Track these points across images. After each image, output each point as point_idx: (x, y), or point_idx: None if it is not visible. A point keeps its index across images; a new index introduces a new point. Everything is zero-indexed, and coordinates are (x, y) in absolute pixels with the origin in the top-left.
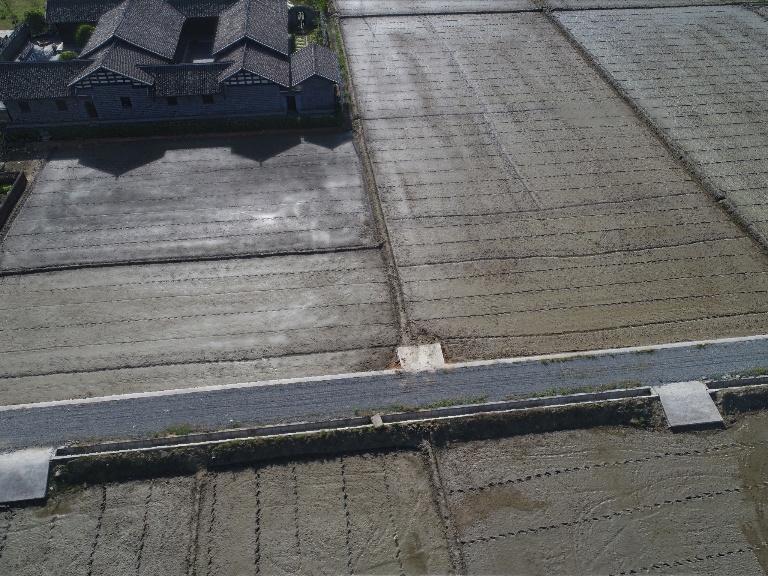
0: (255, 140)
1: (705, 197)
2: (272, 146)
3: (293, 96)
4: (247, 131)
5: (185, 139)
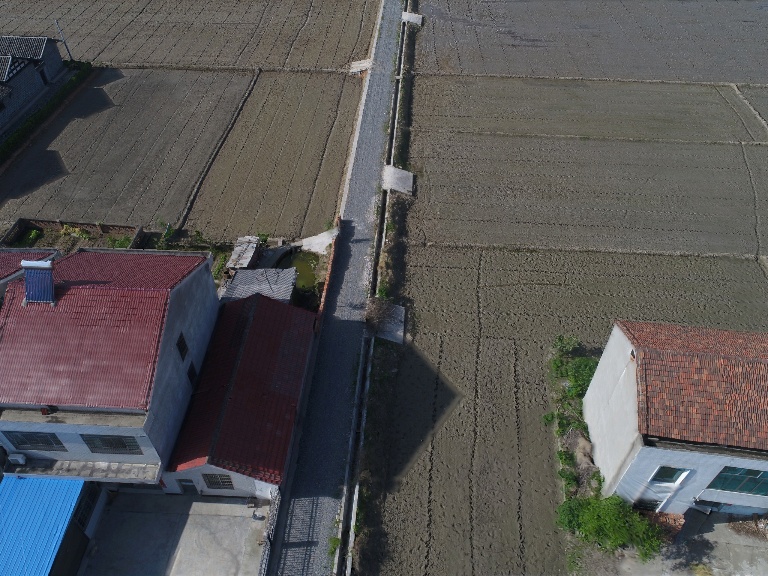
0: (75, 107)
1: None
2: (94, 100)
3: (42, 69)
4: (58, 108)
5: (35, 140)
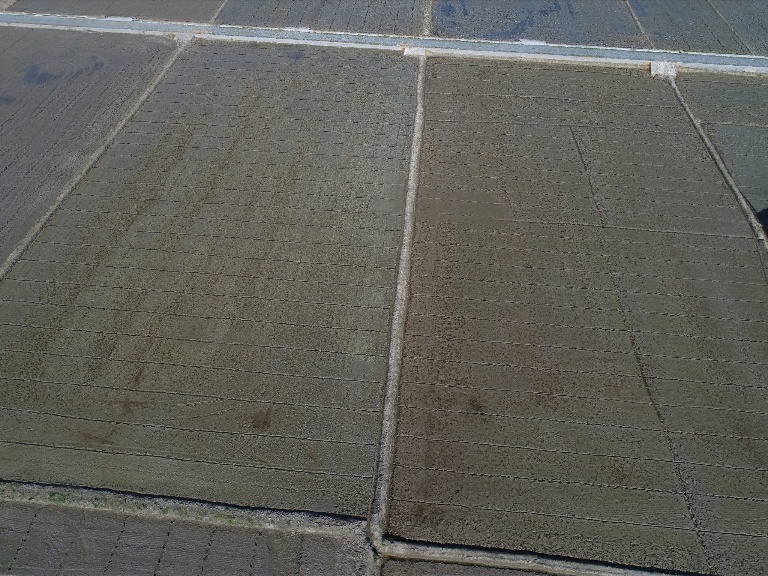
0: None
1: (428, 117)
2: None
3: None
4: None
5: None
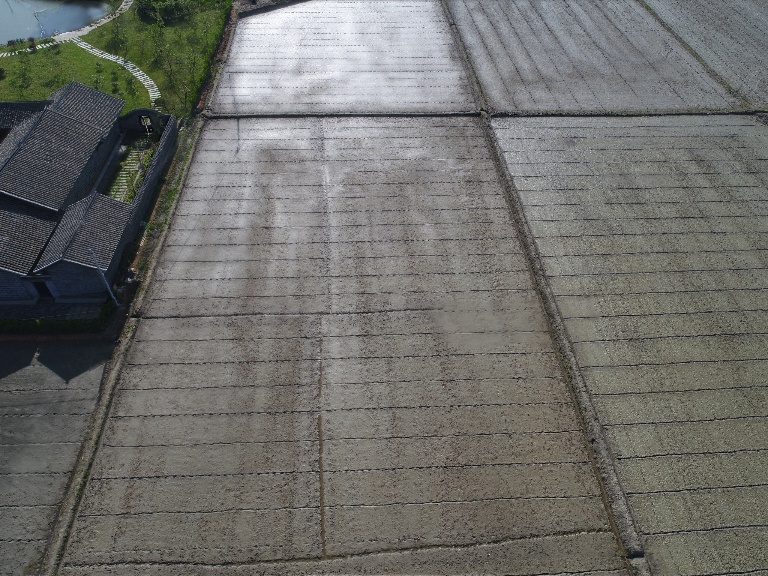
0: None
1: (611, 543)
2: None
3: (42, 282)
4: None
5: None
